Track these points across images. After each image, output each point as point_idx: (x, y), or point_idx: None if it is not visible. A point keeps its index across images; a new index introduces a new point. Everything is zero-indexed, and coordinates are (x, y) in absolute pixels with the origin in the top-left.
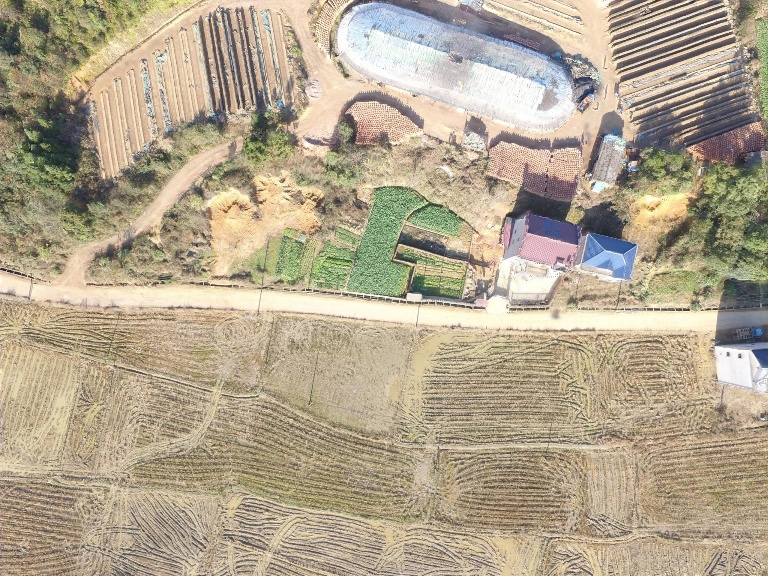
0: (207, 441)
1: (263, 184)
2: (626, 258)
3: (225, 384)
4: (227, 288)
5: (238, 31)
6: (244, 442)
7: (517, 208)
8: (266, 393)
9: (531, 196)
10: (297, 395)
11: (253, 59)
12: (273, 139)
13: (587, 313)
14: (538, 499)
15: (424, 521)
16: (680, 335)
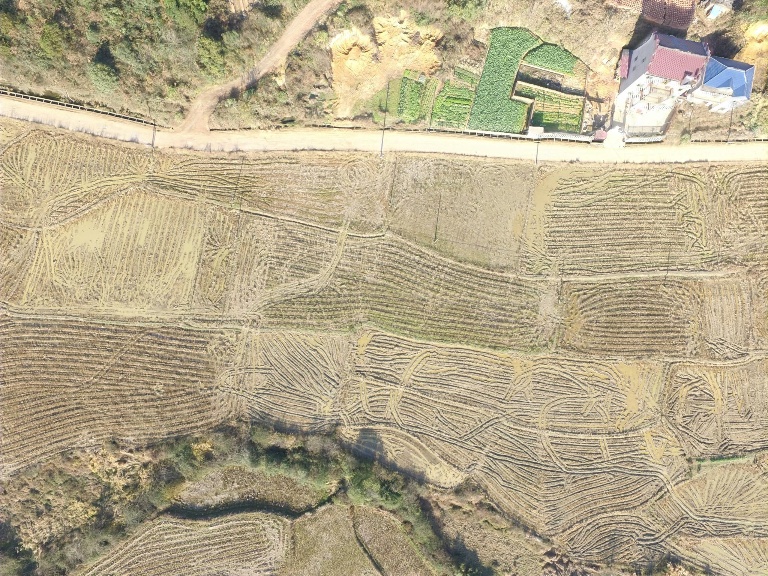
0: (336, 280)
1: (382, 26)
2: (747, 76)
3: (351, 224)
4: (350, 130)
5: None
6: (372, 280)
7: (634, 39)
8: (392, 231)
9: (650, 24)
10: (422, 233)
11: None
12: None
13: (699, 145)
14: (659, 325)
15: (550, 350)
16: None
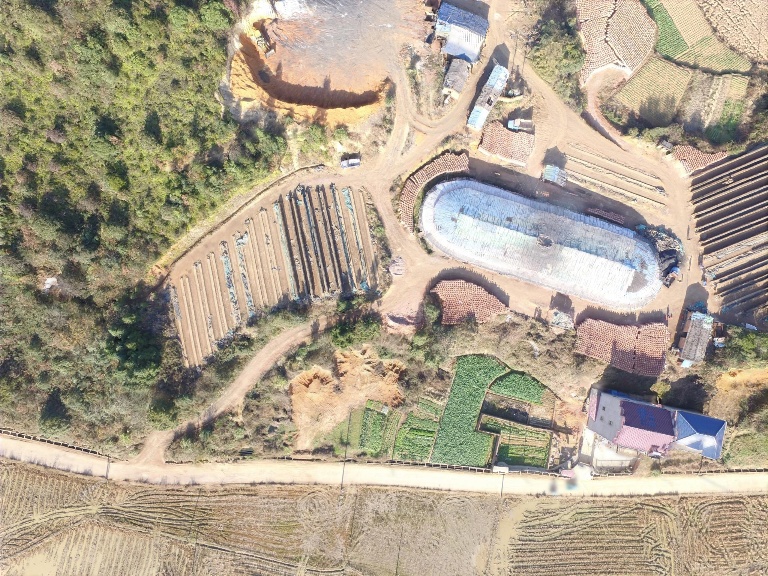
0: None
1: (344, 356)
2: (717, 438)
3: (310, 559)
4: (309, 462)
5: (320, 211)
6: None
7: (603, 380)
8: (352, 567)
9: (618, 372)
10: (383, 568)
11: (336, 239)
12: (357, 317)
13: (670, 477)
14: None
15: None
16: (761, 495)
